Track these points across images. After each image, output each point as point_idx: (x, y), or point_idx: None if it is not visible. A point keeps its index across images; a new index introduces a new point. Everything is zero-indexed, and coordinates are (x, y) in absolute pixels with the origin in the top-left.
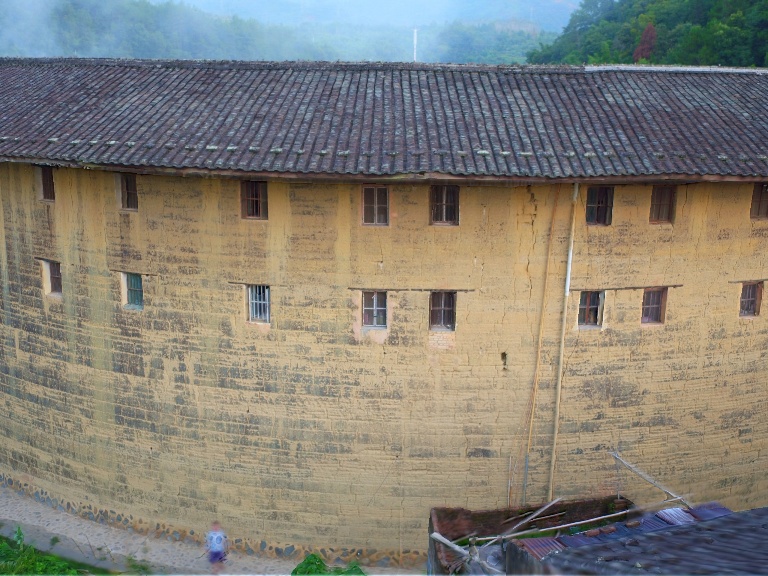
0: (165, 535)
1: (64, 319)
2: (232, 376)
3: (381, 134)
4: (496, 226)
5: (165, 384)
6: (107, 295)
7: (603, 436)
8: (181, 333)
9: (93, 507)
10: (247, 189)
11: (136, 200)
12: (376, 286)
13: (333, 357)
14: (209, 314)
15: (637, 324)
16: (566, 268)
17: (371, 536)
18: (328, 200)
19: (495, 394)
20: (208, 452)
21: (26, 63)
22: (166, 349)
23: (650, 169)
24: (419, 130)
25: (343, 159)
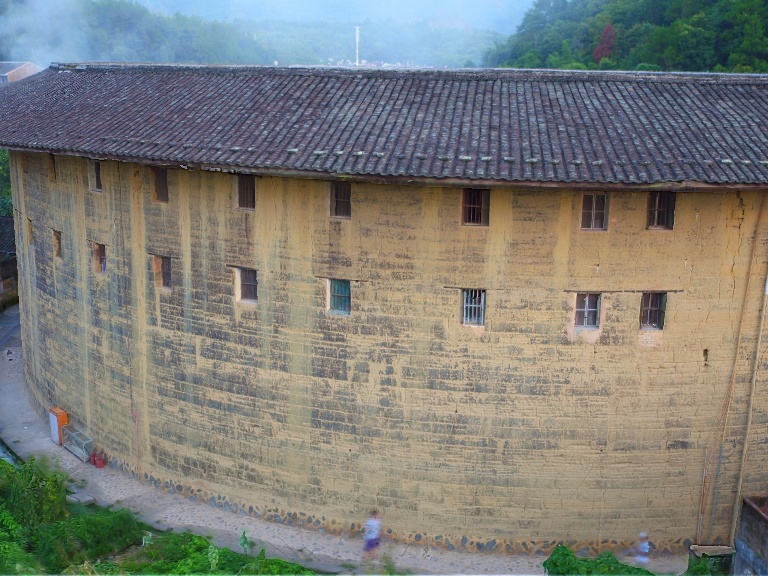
0: (360, 535)
1: (258, 325)
2: (442, 378)
3: (622, 144)
4: (707, 230)
5: (370, 387)
6: (310, 301)
7: None
8: (390, 337)
9: (280, 510)
10: (465, 197)
11: (346, 208)
12: (591, 288)
13: (545, 357)
14: (421, 318)
15: None
16: (767, 268)
17: (572, 528)
18: (550, 207)
19: (696, 389)
20: (412, 452)
21: (203, 72)
22: (373, 353)
23: None
24: (656, 140)
25: (598, 168)
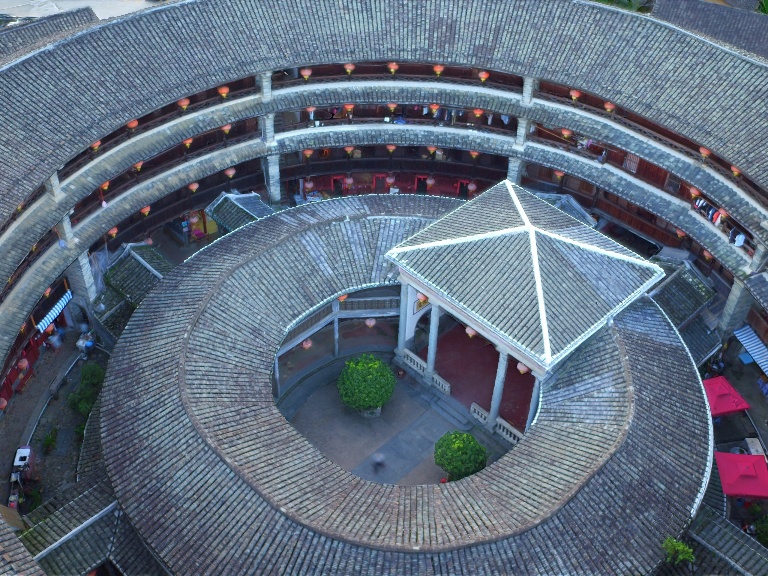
0: None
1: None
2: None
3: None
4: None
5: None
6: None
7: None
8: None
9: None
10: None
11: None
12: None
13: None
14: None
15: None
16: None
17: None
18: None
19: None
20: None
21: None
22: None
23: None
24: None
25: None
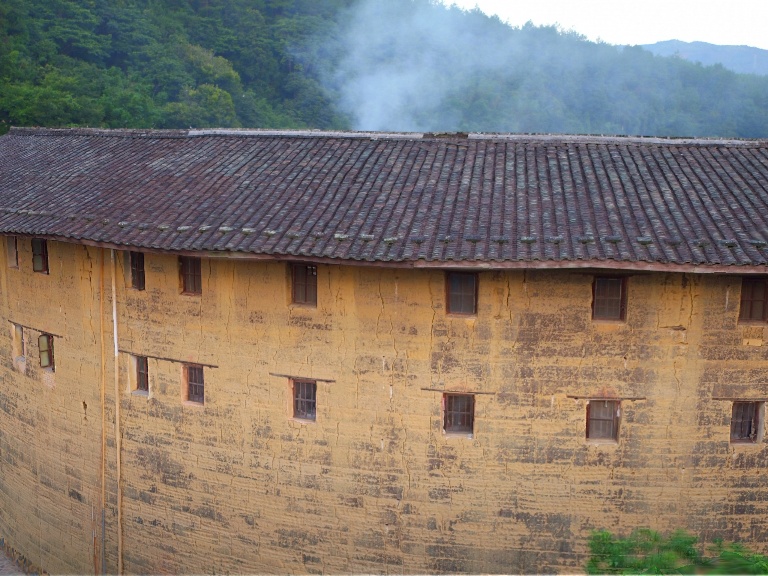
0: None
1: None
2: None
3: None
4: (69, 279)
5: None
6: None
7: (159, 512)
8: None
9: None
10: None
11: None
12: None
13: (7, 379)
14: None
15: (178, 399)
16: None
17: (29, 548)
18: None
19: (81, 441)
20: None
21: None
22: None
23: (43, 229)
24: None
25: None
